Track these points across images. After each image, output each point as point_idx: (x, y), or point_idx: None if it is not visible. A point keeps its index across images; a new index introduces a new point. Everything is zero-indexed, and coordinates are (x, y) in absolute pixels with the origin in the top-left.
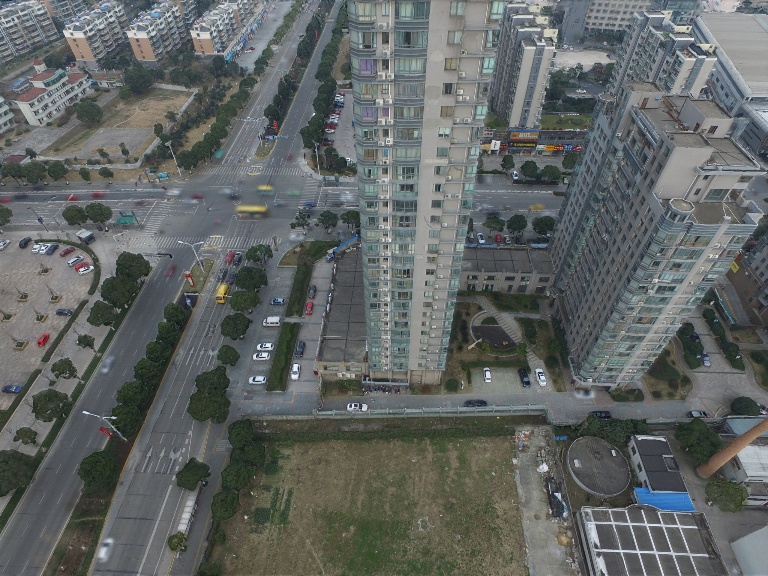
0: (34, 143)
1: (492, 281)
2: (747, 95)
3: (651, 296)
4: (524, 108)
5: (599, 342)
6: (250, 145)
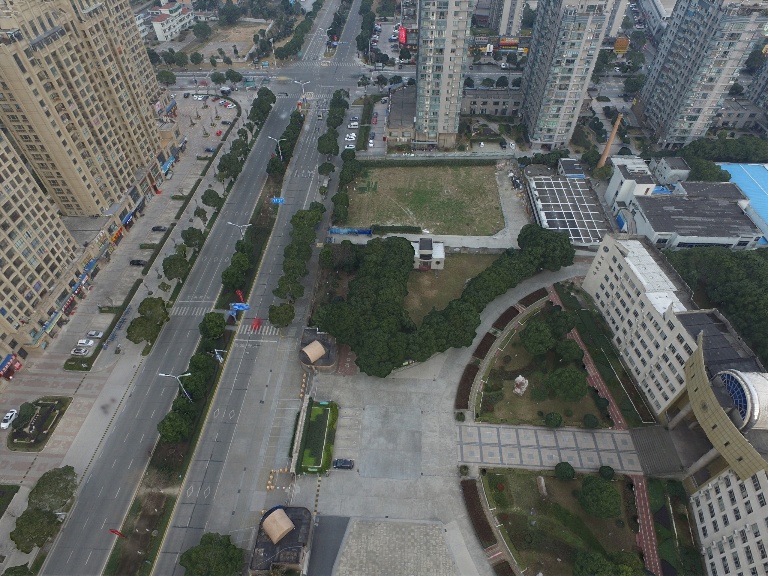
0: (167, 50)
1: (485, 106)
2: (663, 15)
3: (564, 68)
4: (509, 20)
5: (541, 108)
6: (319, 51)
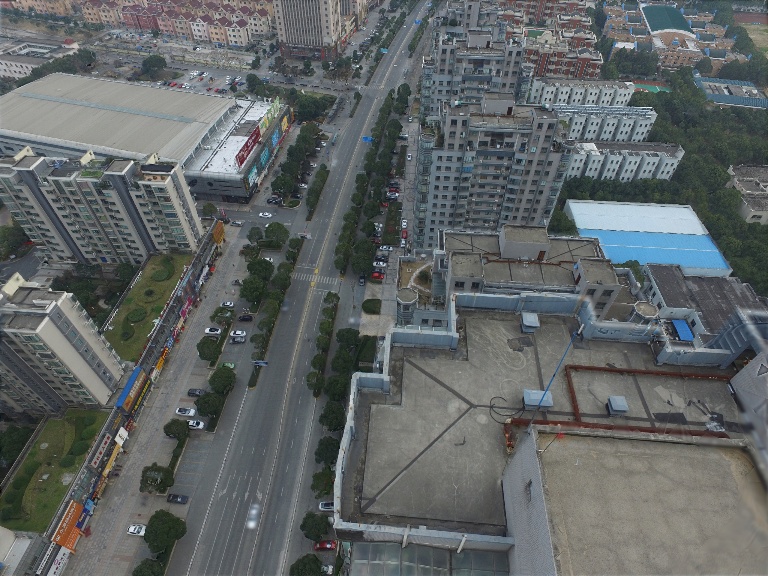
0: None
1: None
2: None
3: None
4: (100, 374)
5: None
6: None
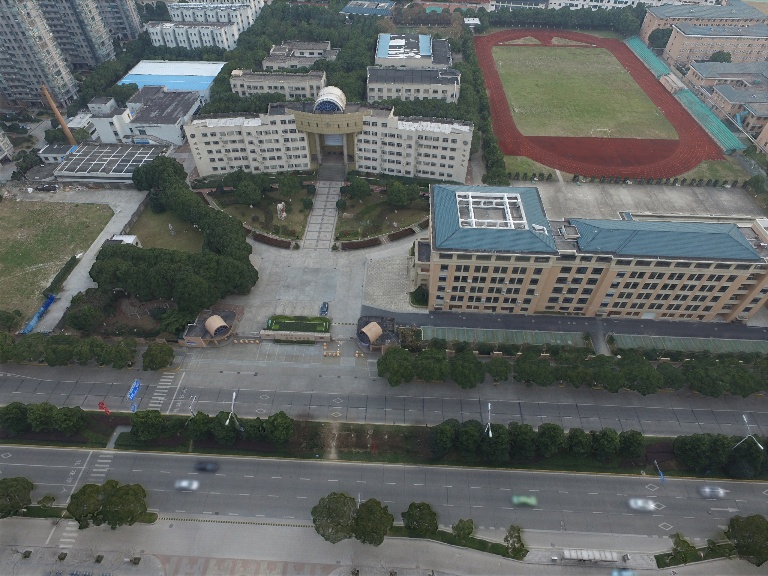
0: None
1: None
2: None
3: None
4: None
5: None
6: None
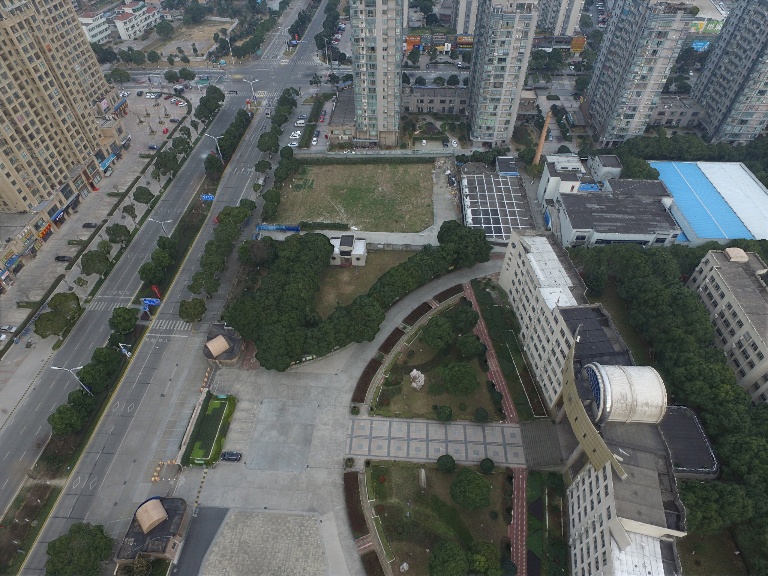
0: None
1: (432, 104)
2: None
3: (496, 66)
4: (466, 19)
5: (479, 106)
6: (279, 50)
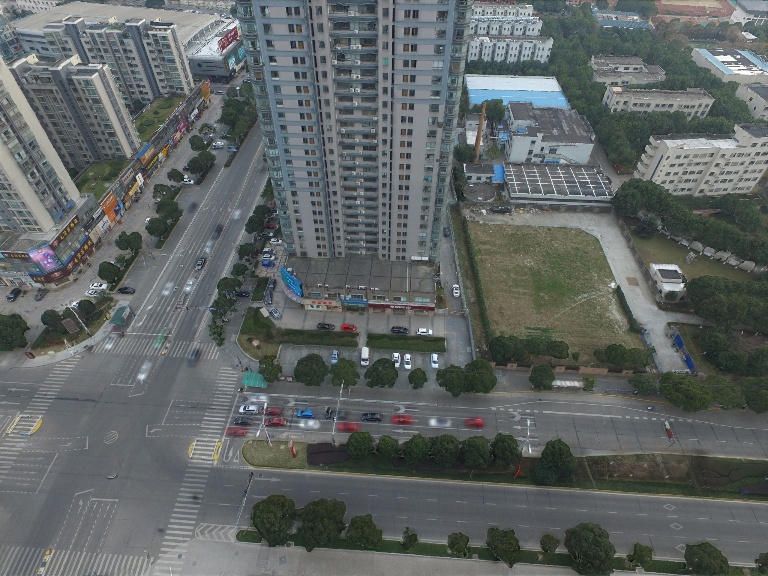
0: None
1: None
2: None
3: None
4: (126, 133)
5: None
6: None
